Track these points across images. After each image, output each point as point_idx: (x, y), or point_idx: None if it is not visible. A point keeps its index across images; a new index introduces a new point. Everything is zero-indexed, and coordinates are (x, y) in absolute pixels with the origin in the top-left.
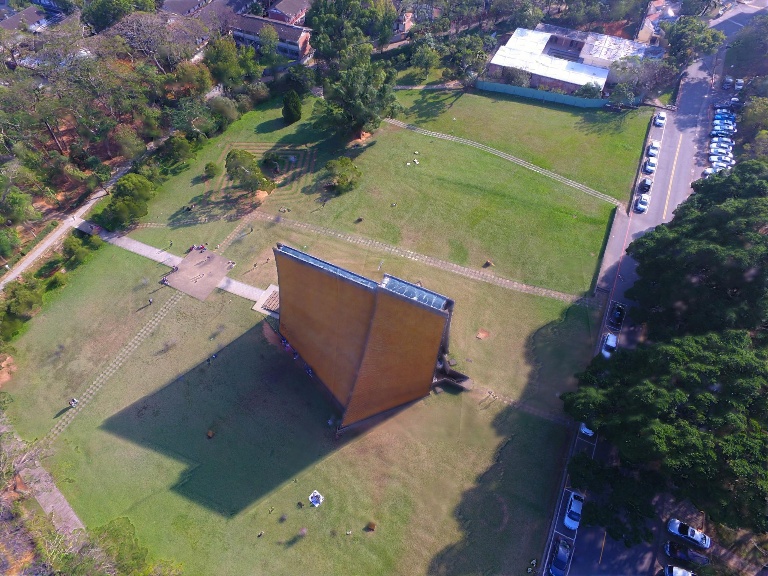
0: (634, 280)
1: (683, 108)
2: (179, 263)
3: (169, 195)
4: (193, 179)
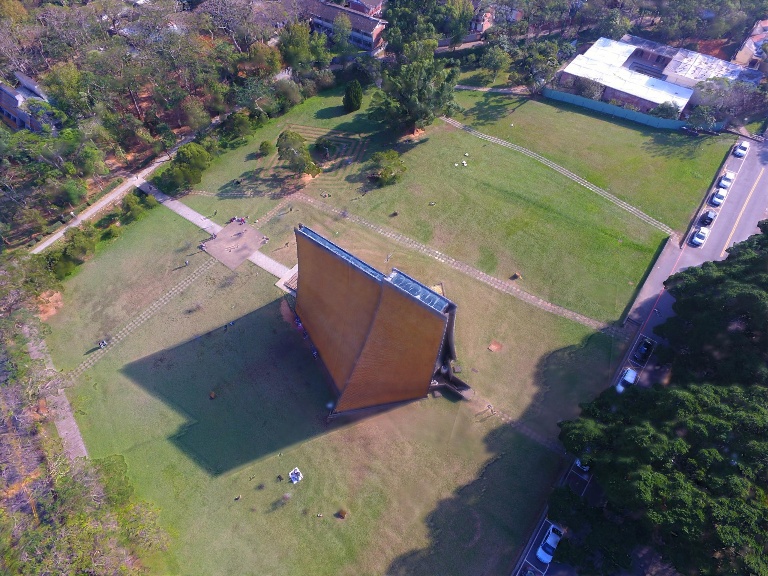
0: None
1: None
2: (219, 232)
3: (223, 167)
4: (248, 155)
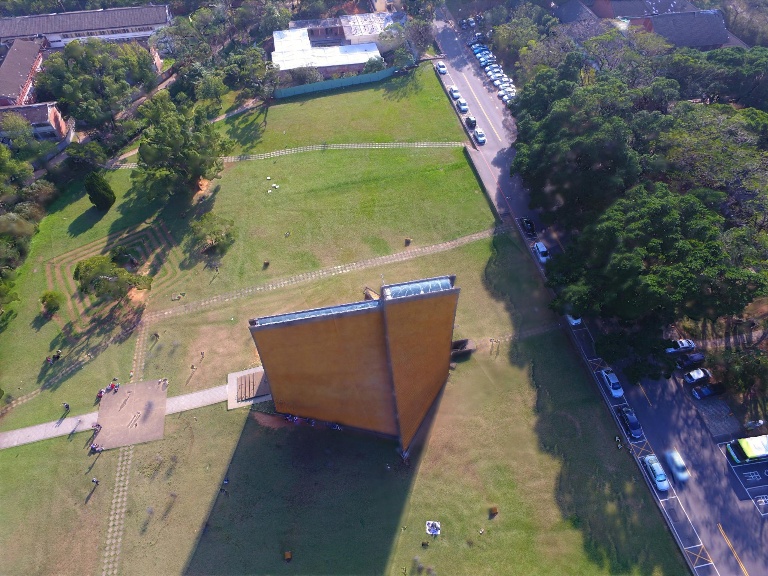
0: (518, 196)
1: (449, 54)
2: (97, 419)
3: (14, 357)
4: (32, 323)
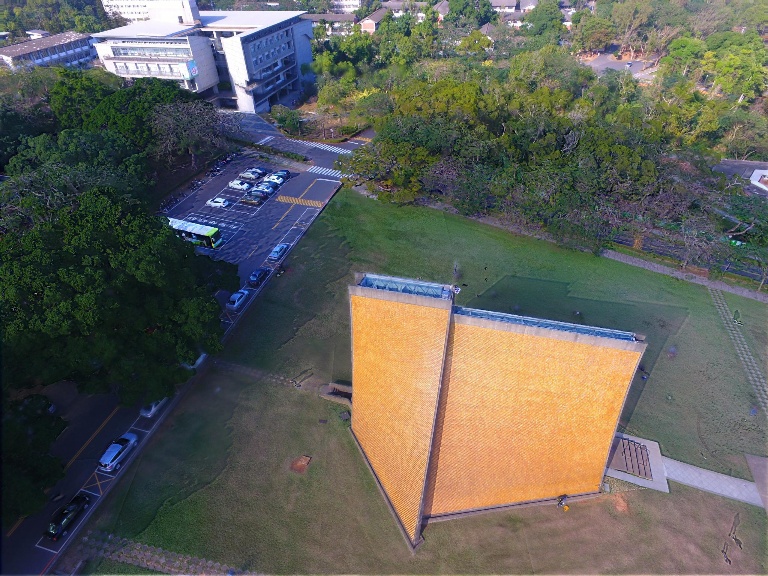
0: None
1: None
2: None
3: None
4: None
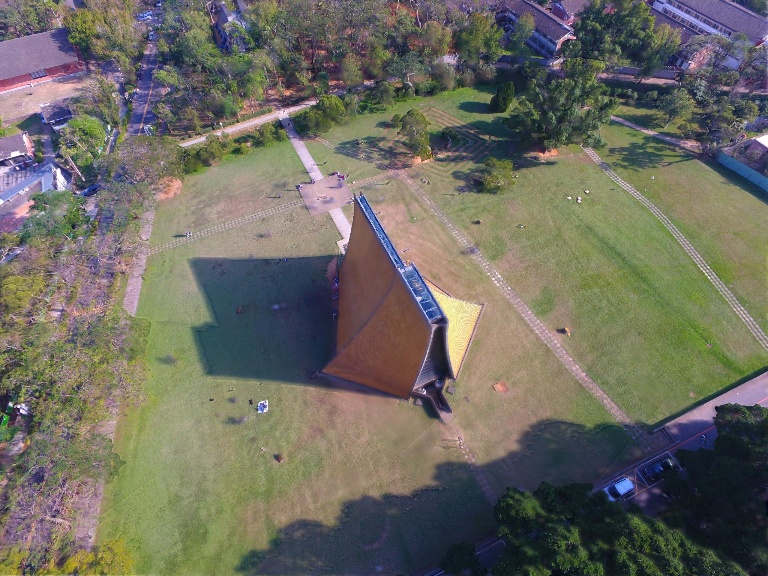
0: None
1: None
2: (319, 179)
3: (354, 126)
4: (380, 122)
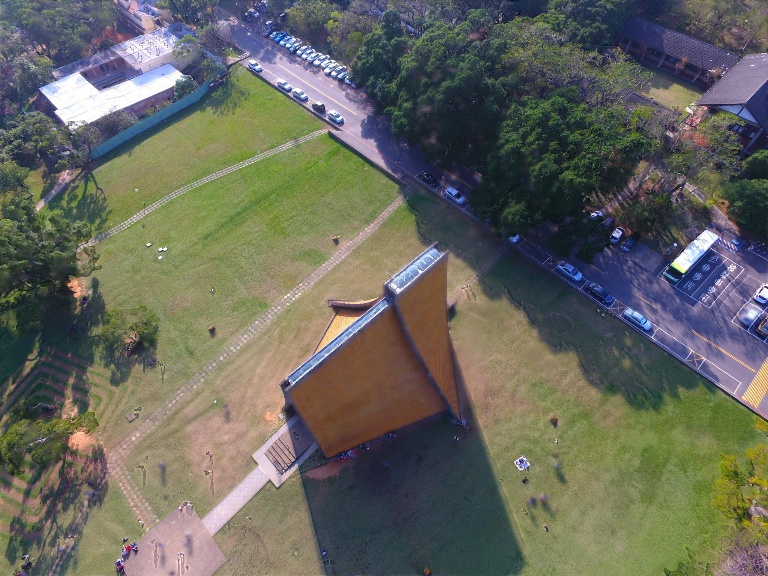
0: (403, 156)
1: (252, 50)
2: None
3: None
4: None
